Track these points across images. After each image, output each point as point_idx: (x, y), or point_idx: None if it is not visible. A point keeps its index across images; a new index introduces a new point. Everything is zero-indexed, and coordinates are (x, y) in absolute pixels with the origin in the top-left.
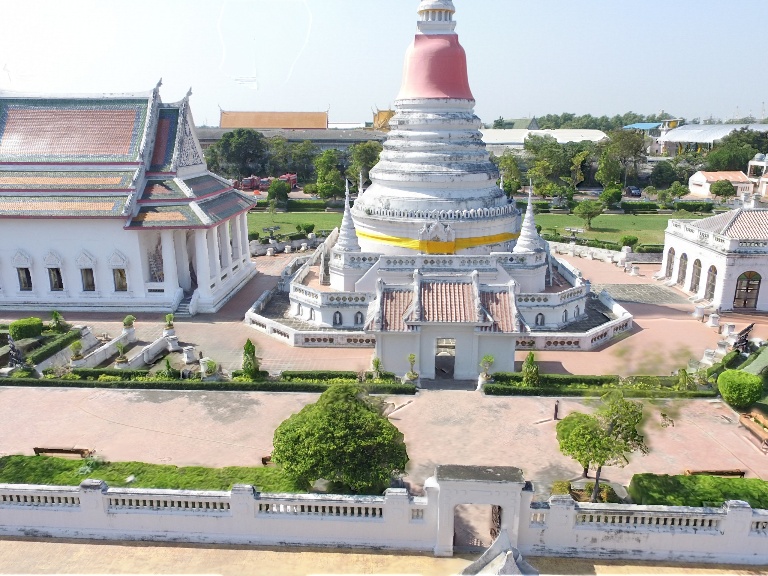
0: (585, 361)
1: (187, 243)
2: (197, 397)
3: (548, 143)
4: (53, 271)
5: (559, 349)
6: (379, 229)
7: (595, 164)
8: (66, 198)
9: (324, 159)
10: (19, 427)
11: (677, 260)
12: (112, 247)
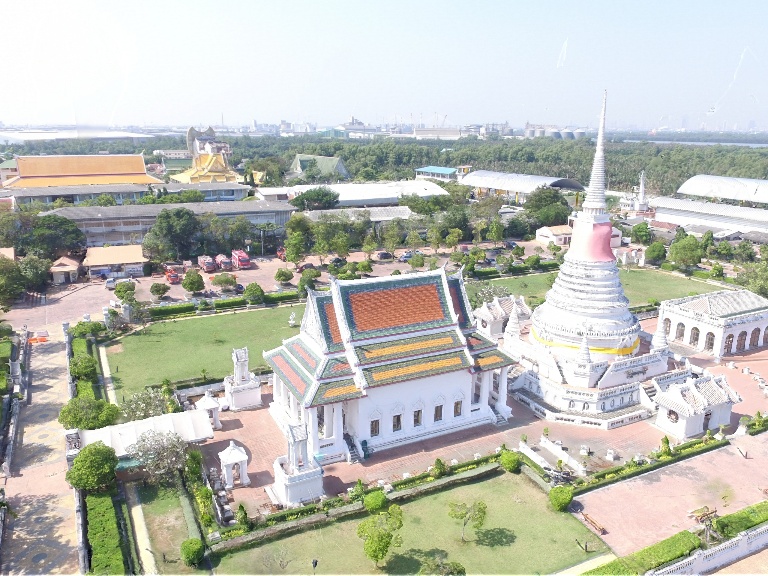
0: None
1: None
2: (666, 473)
3: (420, 202)
4: (414, 412)
5: None
6: (589, 344)
7: (474, 223)
8: (427, 359)
9: (296, 241)
10: None
11: (675, 326)
12: (457, 387)
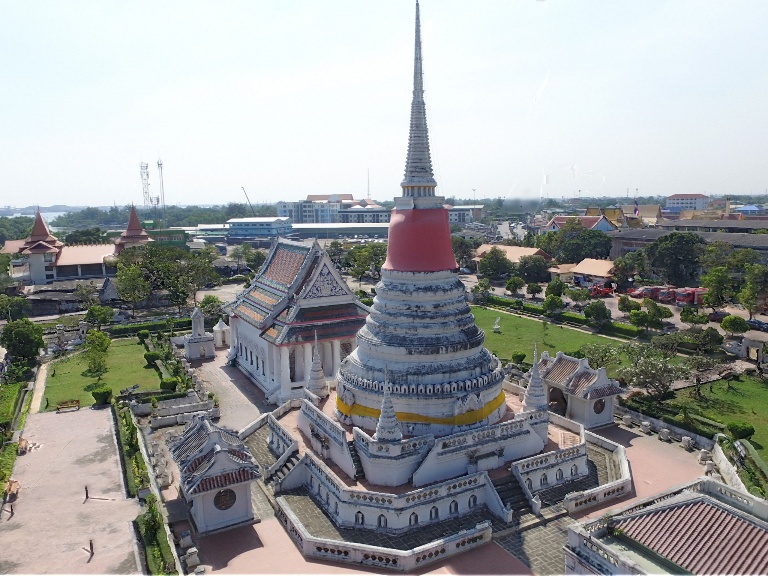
0: (274, 558)
1: (320, 352)
2: None
3: None
4: None
5: (295, 539)
6: None
7: None
8: None
9: (709, 277)
10: (62, 428)
11: None
12: None
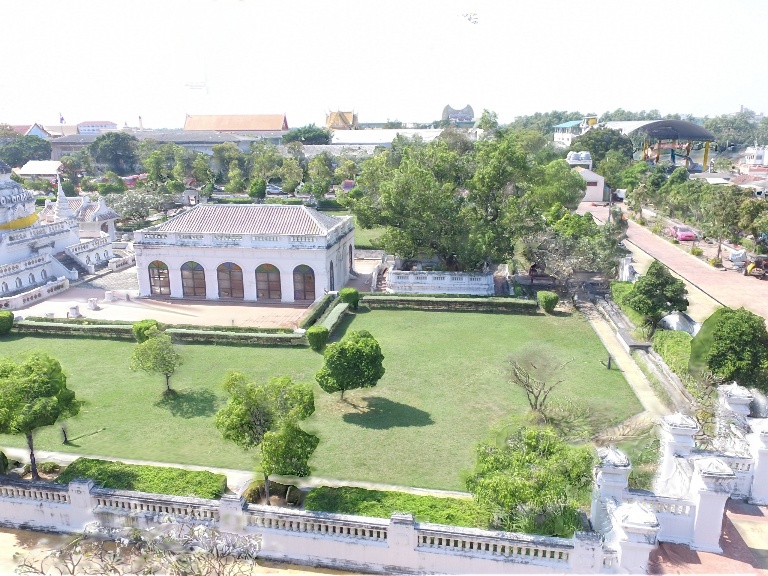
0: None
1: None
2: None
3: None
4: None
5: None
6: None
7: None
8: None
9: (149, 160)
10: None
11: None
12: None
